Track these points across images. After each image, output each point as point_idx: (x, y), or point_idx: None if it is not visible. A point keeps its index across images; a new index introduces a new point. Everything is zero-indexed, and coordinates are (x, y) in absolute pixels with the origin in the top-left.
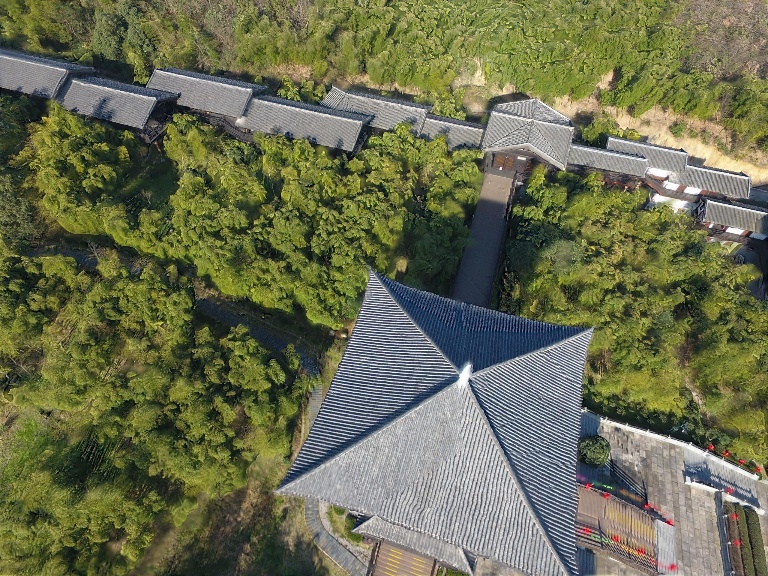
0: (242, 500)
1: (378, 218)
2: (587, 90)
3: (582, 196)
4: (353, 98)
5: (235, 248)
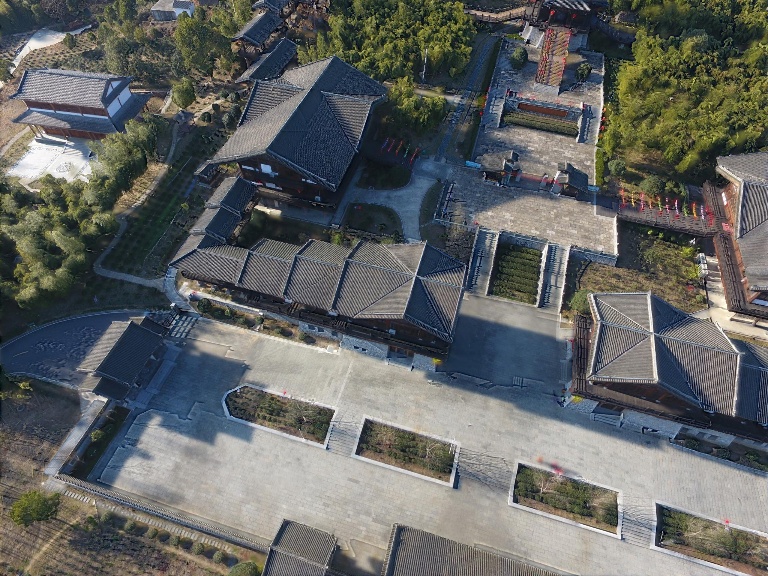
0: (526, 1)
1: None
2: None
3: (767, 67)
4: None
5: None
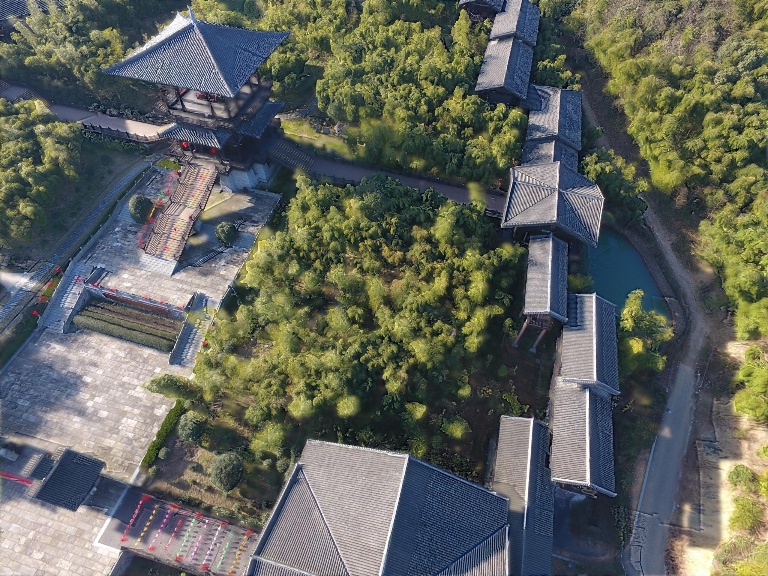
0: None
1: (400, 102)
2: (742, 324)
3: (470, 241)
4: (558, 94)
5: (355, 42)
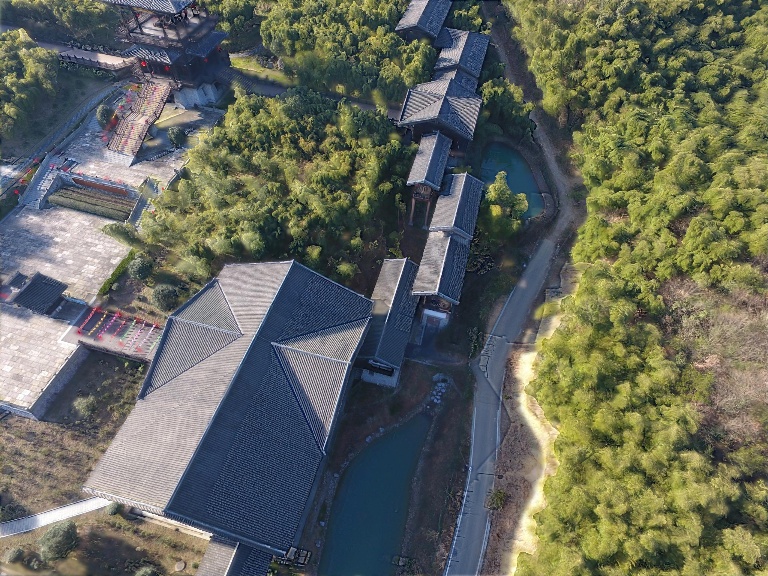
0: None
1: None
2: None
3: (372, 137)
4: None
5: None
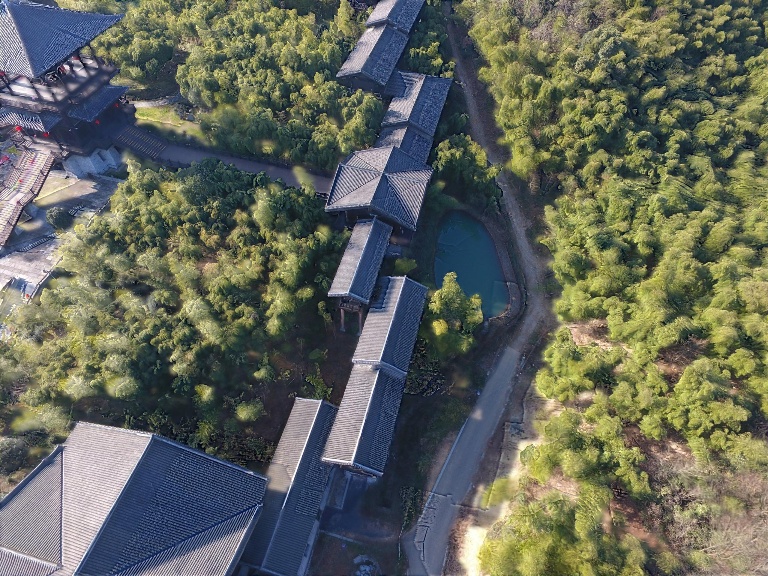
0: None
1: None
2: None
3: (291, 225)
4: None
5: None
